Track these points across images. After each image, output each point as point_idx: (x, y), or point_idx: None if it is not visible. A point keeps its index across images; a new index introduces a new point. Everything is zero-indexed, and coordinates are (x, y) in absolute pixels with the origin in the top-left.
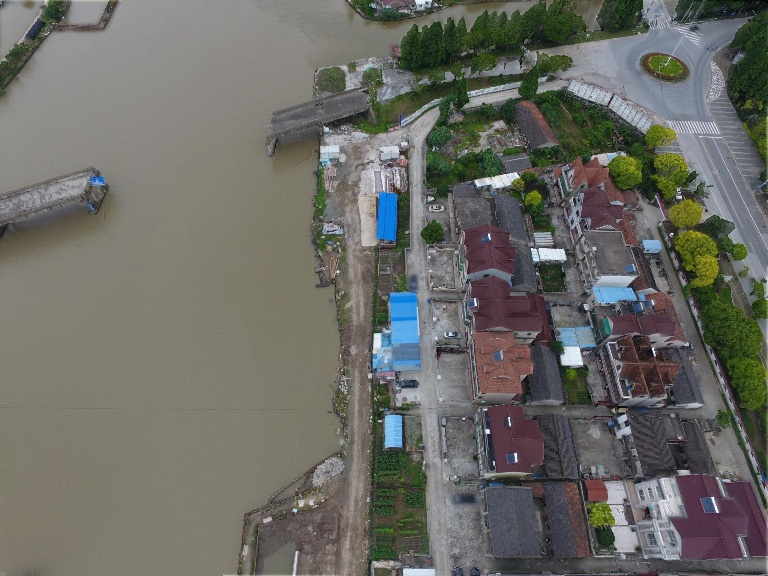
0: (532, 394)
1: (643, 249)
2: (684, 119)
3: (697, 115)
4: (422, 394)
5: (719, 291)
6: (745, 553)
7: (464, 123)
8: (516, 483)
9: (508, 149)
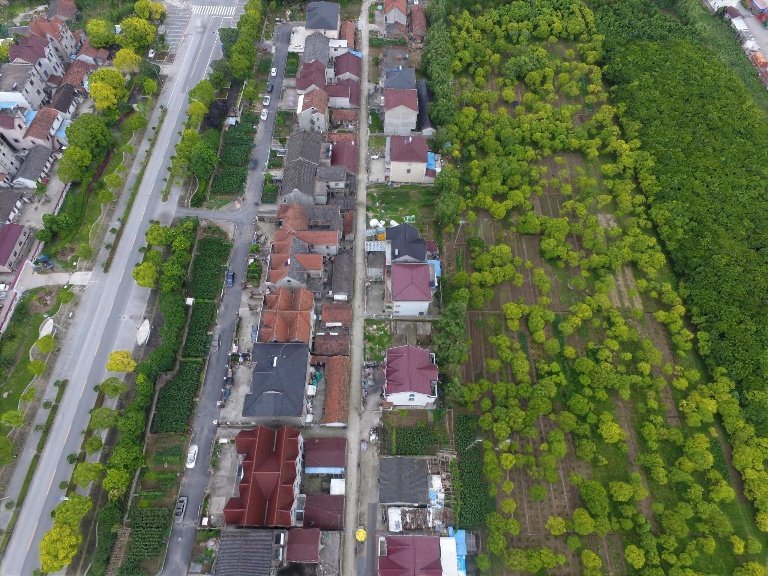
0: None
1: (83, 88)
2: (209, 4)
3: (224, 2)
4: None
5: (129, 116)
6: None
7: (7, 5)
8: None
9: (24, 21)
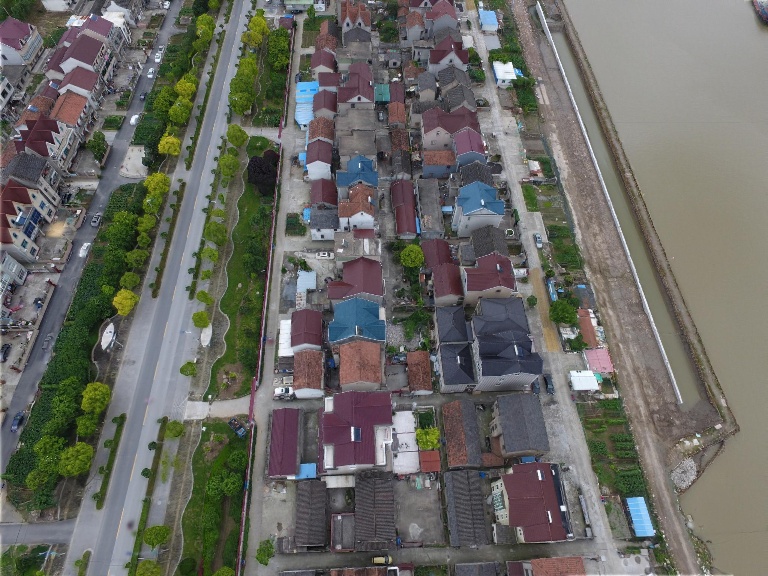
0: (495, 574)
1: None
2: None
3: None
4: (620, 569)
5: None
6: (326, 401)
7: None
8: (508, 465)
9: None
